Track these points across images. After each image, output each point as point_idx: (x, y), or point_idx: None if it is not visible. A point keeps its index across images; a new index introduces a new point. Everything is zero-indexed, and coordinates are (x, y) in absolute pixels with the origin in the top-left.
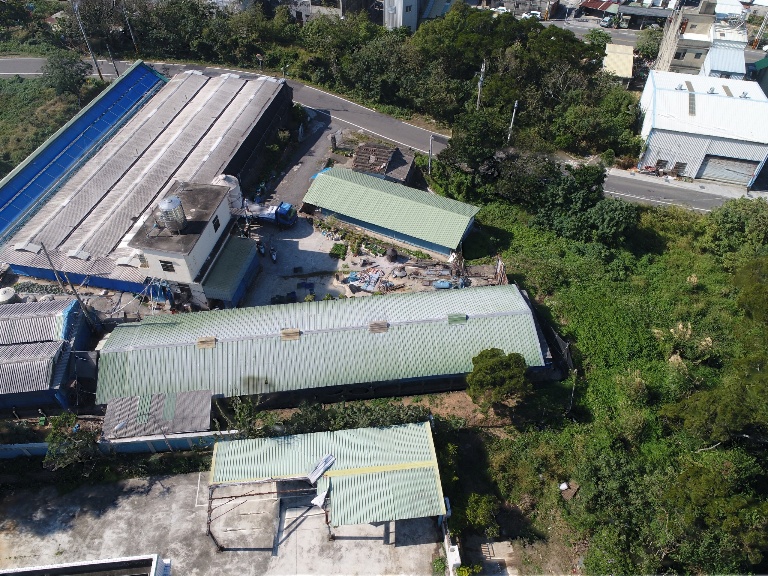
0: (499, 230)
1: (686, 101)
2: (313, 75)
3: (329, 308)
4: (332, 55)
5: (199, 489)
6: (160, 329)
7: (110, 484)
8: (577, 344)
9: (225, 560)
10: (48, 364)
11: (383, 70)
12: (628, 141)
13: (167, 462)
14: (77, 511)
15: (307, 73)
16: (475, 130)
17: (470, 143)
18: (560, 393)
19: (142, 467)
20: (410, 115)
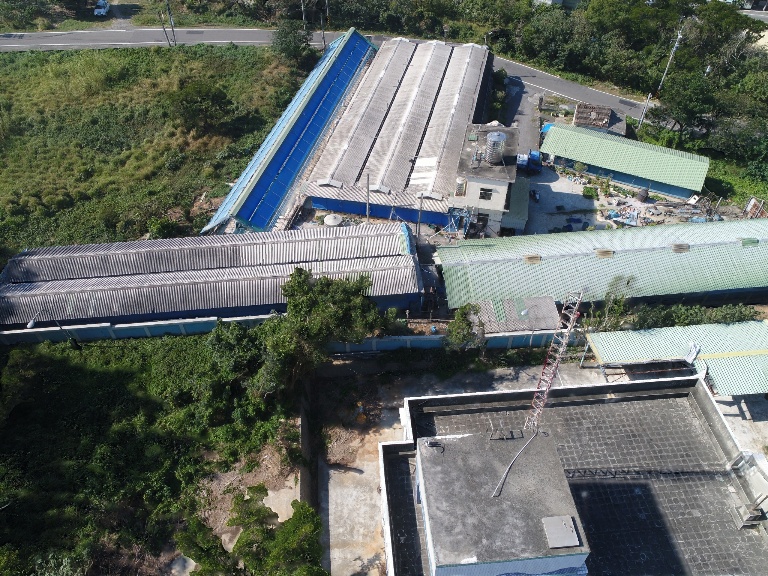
0: (717, 180)
1: None
2: (494, 45)
3: (622, 234)
4: (519, 25)
5: (561, 377)
6: (481, 249)
7: (481, 372)
8: None
9: None
10: (412, 272)
11: (565, 40)
12: None
13: (525, 356)
14: None
15: (488, 44)
16: (696, 88)
17: (692, 99)
18: None
19: (503, 360)
20: (592, 82)
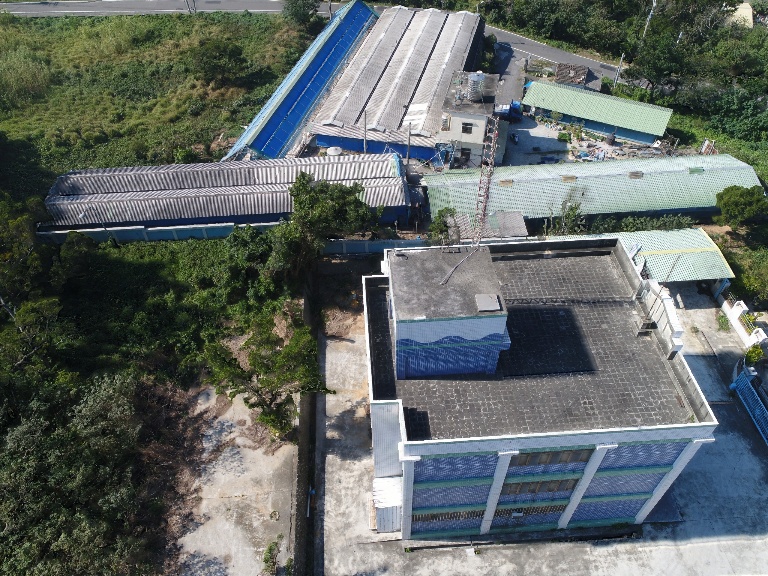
0: (682, 131)
1: None
2: (487, 16)
3: (586, 166)
4: None
5: None
6: (462, 176)
7: None
8: None
9: None
10: (401, 188)
11: (552, 11)
12: None
13: None
14: None
15: (481, 14)
16: (664, 47)
17: (660, 58)
18: None
19: None
20: (576, 49)
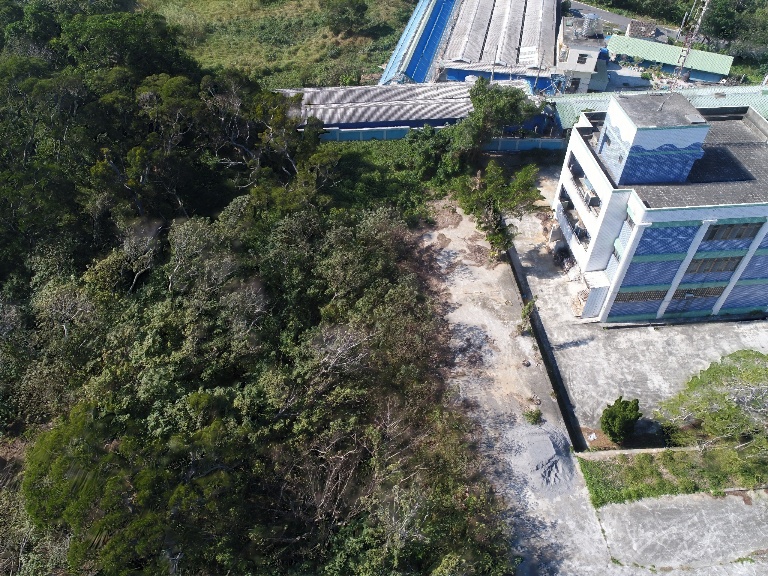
0: None
1: None
2: None
3: None
4: None
5: None
6: (579, 97)
7: None
8: None
9: None
10: (539, 101)
11: None
12: None
13: None
14: None
15: None
16: (722, 7)
17: (719, 15)
18: None
19: None
20: (634, 16)
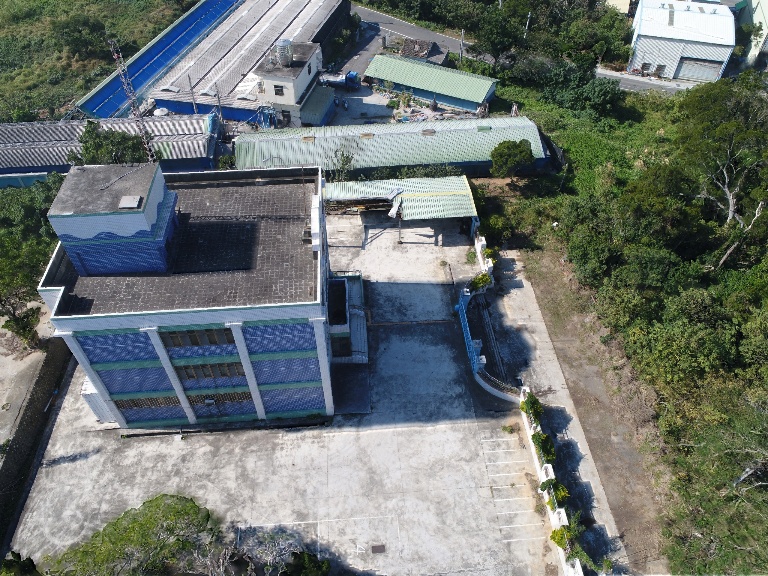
0: (514, 101)
1: (667, 16)
2: None
3: (391, 126)
4: None
5: None
6: (273, 134)
7: None
8: (569, 155)
9: (331, 251)
10: (204, 142)
11: None
12: (619, 49)
13: None
14: None
15: None
16: (497, 23)
17: (493, 33)
18: (555, 179)
19: None
20: (443, 29)
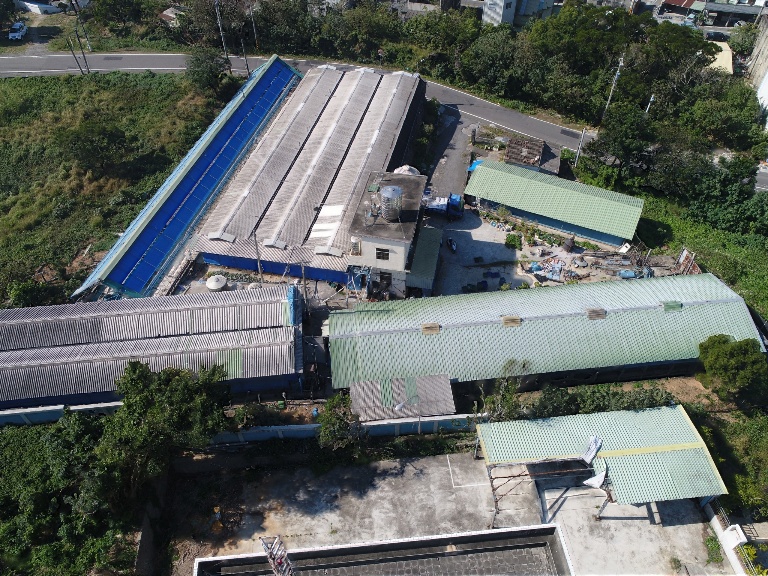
0: (655, 222)
1: None
2: (433, 70)
3: (535, 296)
4: (457, 50)
5: (452, 471)
6: (377, 316)
7: (362, 466)
8: None
9: None
10: (290, 349)
11: (506, 65)
12: (758, 135)
13: (414, 445)
14: (338, 492)
15: (426, 68)
16: (632, 123)
17: (628, 136)
18: None
19: (389, 449)
20: (534, 110)
